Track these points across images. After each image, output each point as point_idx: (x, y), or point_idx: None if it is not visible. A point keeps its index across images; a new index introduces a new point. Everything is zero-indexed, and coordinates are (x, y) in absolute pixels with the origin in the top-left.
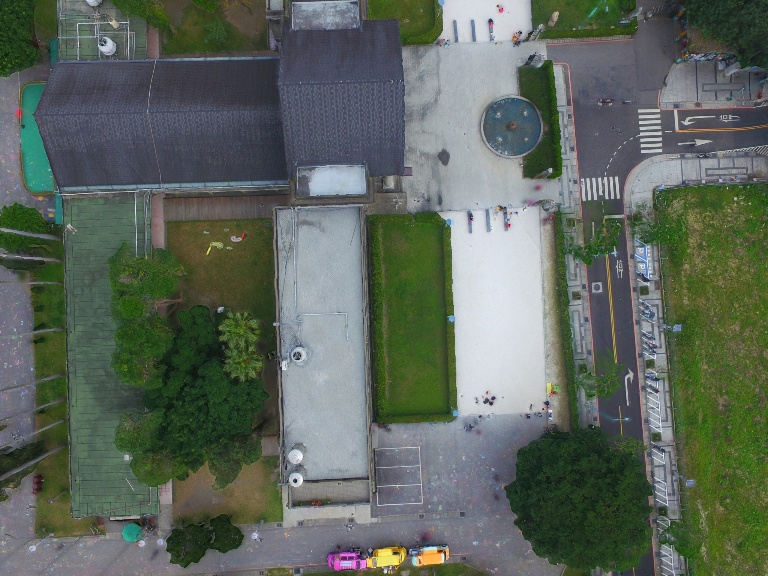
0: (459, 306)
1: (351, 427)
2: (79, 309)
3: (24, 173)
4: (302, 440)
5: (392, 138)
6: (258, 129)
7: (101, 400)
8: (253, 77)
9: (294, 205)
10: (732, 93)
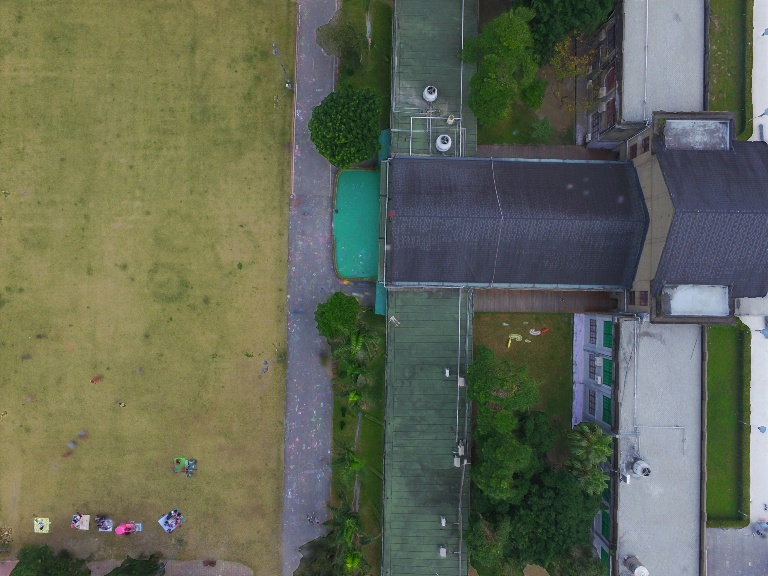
0: (751, 411)
1: (684, 542)
2: (398, 401)
3: (336, 258)
4: (635, 552)
5: (767, 264)
6: (603, 238)
7: (416, 493)
8: (593, 183)
9: (654, 322)
10: None
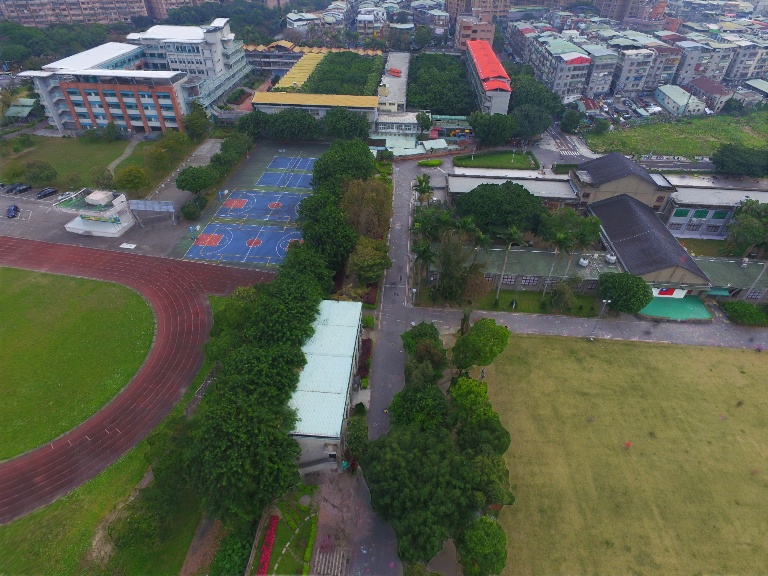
0: None
1: (766, 195)
2: None
3: None
4: None
5: None
6: None
7: None
8: None
9: None
10: (548, 139)
